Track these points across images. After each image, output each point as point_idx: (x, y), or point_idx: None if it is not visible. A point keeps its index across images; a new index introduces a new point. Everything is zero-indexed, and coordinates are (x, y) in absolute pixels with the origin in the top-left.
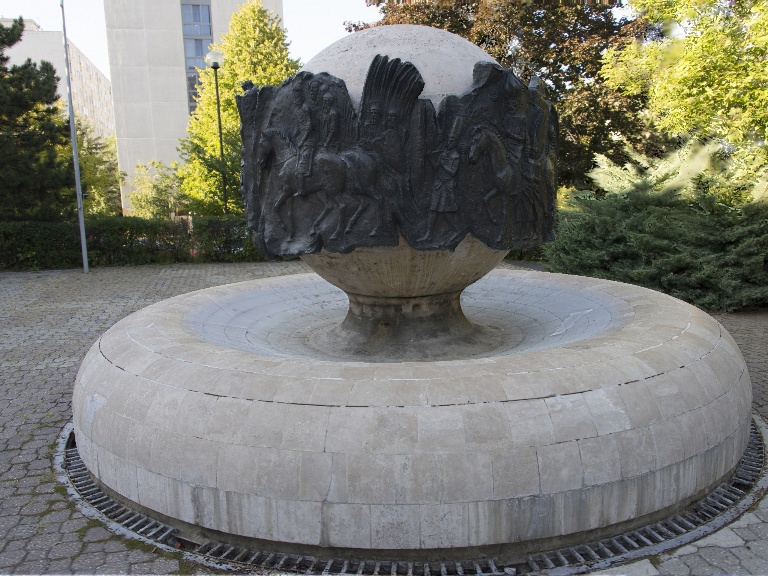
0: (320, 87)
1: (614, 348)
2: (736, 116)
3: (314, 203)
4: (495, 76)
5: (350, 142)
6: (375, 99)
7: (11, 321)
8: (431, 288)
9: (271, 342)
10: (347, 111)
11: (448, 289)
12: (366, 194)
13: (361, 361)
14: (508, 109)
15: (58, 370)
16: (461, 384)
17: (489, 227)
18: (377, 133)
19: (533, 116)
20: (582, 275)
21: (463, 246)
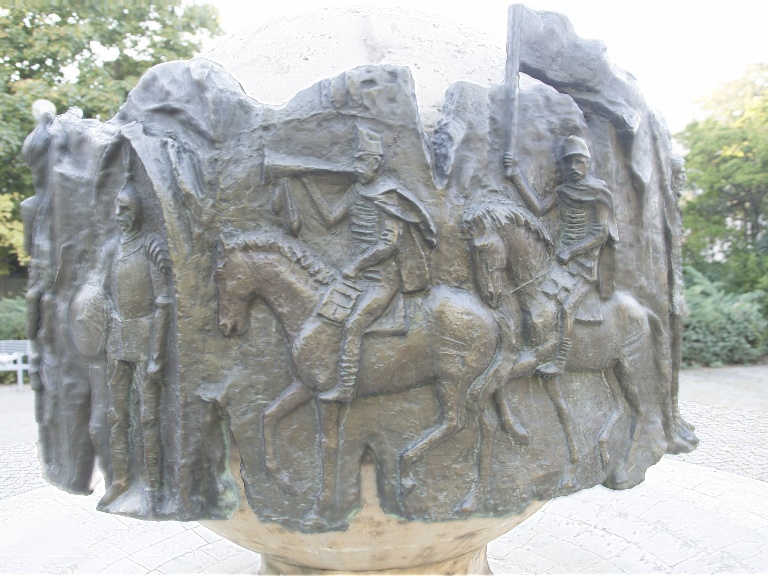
0: None
1: None
2: None
3: None
4: None
5: None
6: None
7: None
8: None
9: None
10: None
11: None
12: None
13: (220, 575)
14: None
15: None
16: None
17: None
18: None
19: None
20: None
21: None
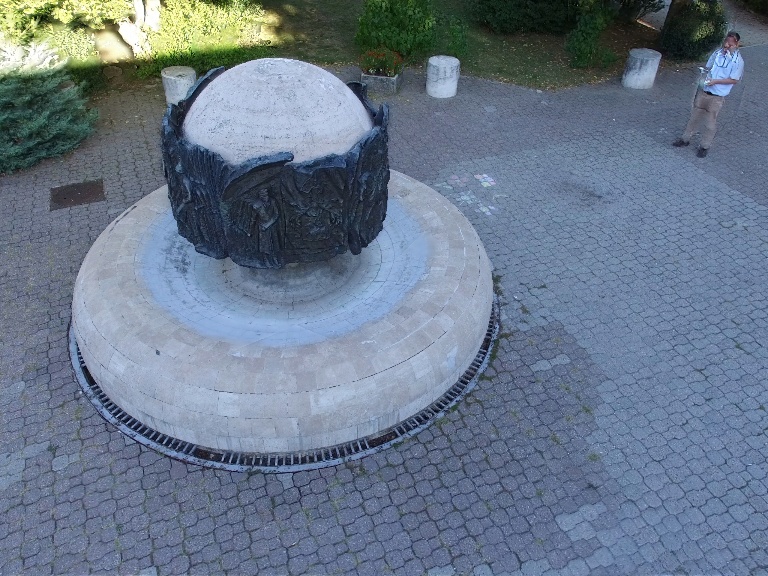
0: None
1: None
2: (81, 4)
3: None
4: None
5: None
6: None
7: None
8: None
9: (319, 313)
10: None
11: None
12: None
13: (358, 271)
14: None
15: (173, 572)
16: (461, 221)
17: None
18: None
19: None
20: None
21: None
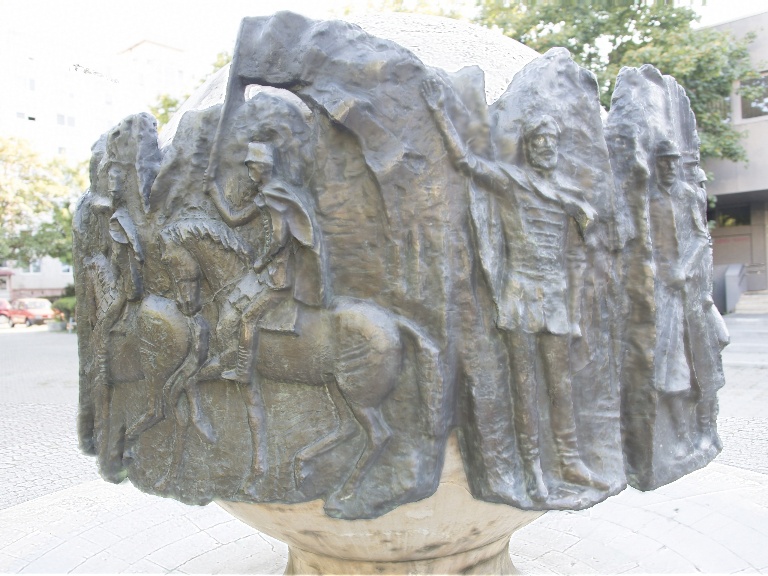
0: None
1: (34, 506)
2: None
3: None
4: None
5: None
6: None
7: None
8: None
9: None
10: None
11: None
12: None
13: None
14: None
15: None
16: None
17: None
18: None
19: None
20: None
21: None
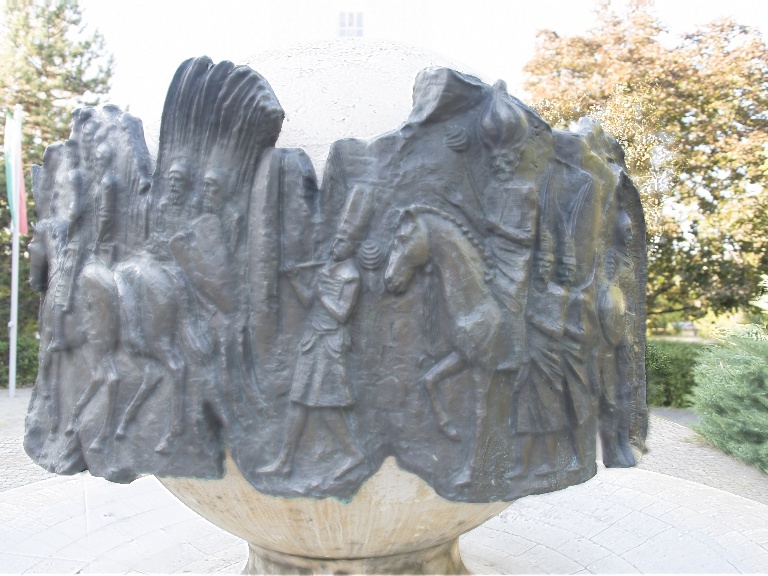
0: (95, 132)
1: None
2: None
3: (78, 367)
4: (459, 97)
5: (133, 242)
6: (180, 150)
7: (1, 460)
8: (356, 549)
9: None
10: (131, 177)
11: (401, 549)
12: (154, 356)
13: None
14: (493, 170)
15: None
16: None
17: (438, 447)
18: (180, 222)
19: (566, 190)
20: (747, 445)
21: (401, 476)
